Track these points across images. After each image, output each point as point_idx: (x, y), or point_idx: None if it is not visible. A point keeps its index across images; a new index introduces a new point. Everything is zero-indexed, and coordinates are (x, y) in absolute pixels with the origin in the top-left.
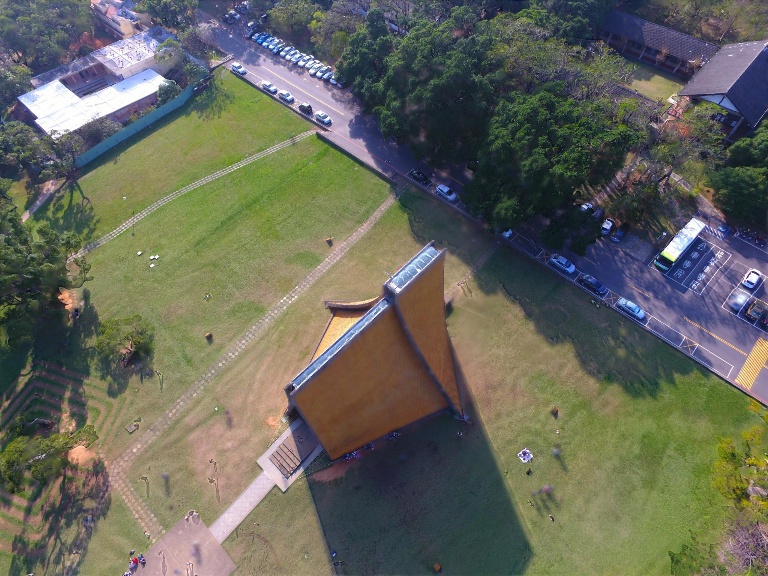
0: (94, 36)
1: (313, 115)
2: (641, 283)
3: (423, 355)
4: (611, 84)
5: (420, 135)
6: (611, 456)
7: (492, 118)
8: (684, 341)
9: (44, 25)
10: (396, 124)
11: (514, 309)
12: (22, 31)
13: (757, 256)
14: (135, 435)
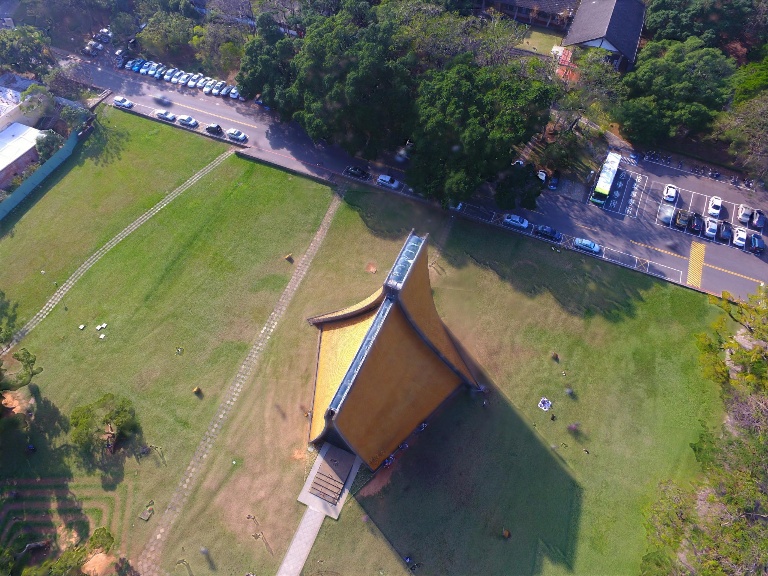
0: None
1: (225, 135)
2: (586, 221)
3: (431, 341)
4: (509, 46)
5: (347, 131)
6: (614, 380)
7: (416, 100)
8: (637, 261)
9: None
10: (323, 125)
11: (488, 275)
12: None
13: (667, 173)
14: (153, 521)
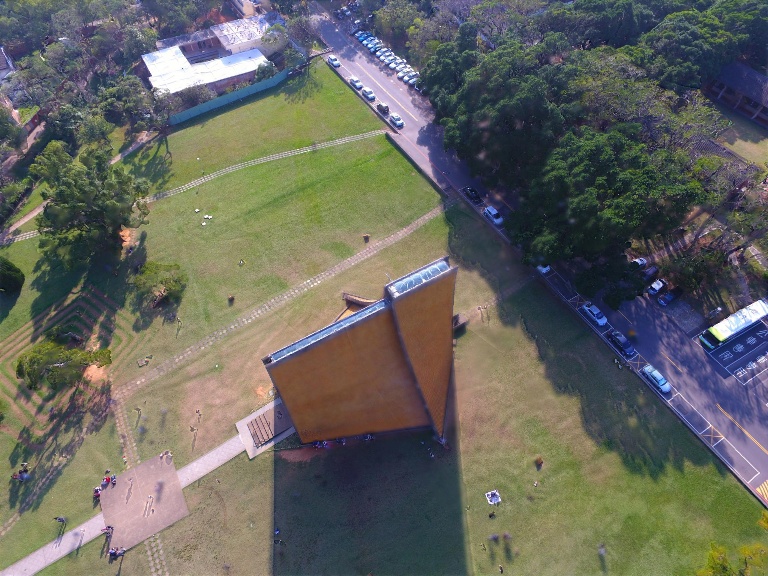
0: (221, 13)
1: (388, 116)
2: (677, 355)
3: (413, 366)
4: (699, 137)
5: (481, 153)
6: (586, 526)
7: (555, 149)
8: (708, 429)
9: None
10: (458, 137)
11: (528, 347)
12: None
13: None
14: (143, 369)
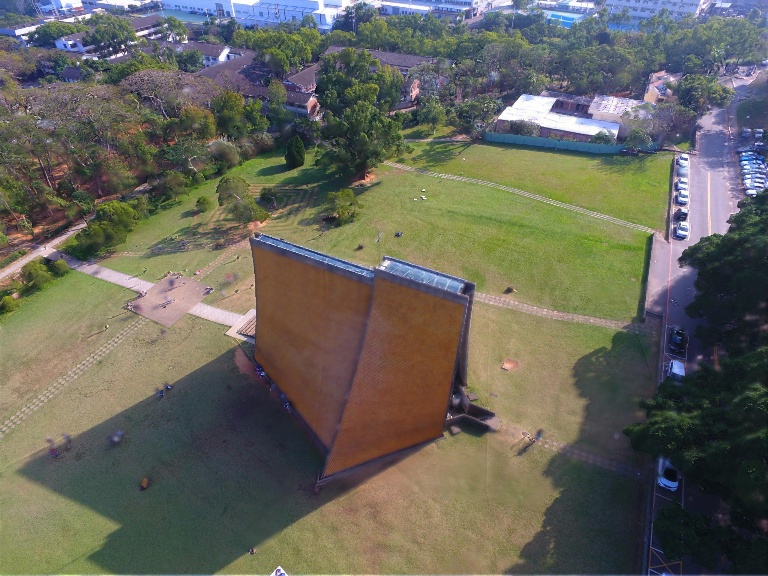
0: None
1: None
2: None
3: (358, 371)
4: None
5: (732, 297)
6: None
7: None
8: None
9: (595, 66)
10: (704, 253)
11: (523, 525)
12: (578, 63)
13: None
14: None
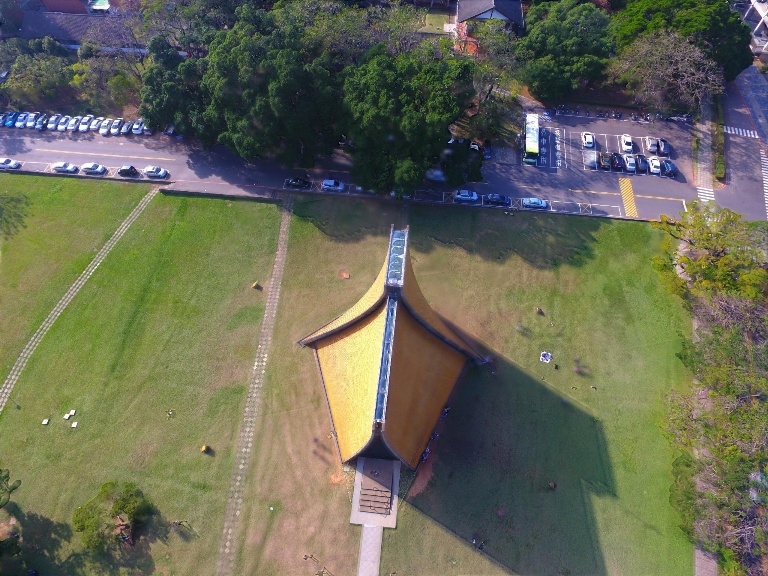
0: None
1: (141, 175)
2: (526, 181)
3: (435, 329)
4: (413, 31)
5: None
6: (596, 317)
7: (343, 98)
8: (581, 207)
9: None
10: (255, 142)
11: (456, 252)
12: None
13: (579, 122)
14: None
